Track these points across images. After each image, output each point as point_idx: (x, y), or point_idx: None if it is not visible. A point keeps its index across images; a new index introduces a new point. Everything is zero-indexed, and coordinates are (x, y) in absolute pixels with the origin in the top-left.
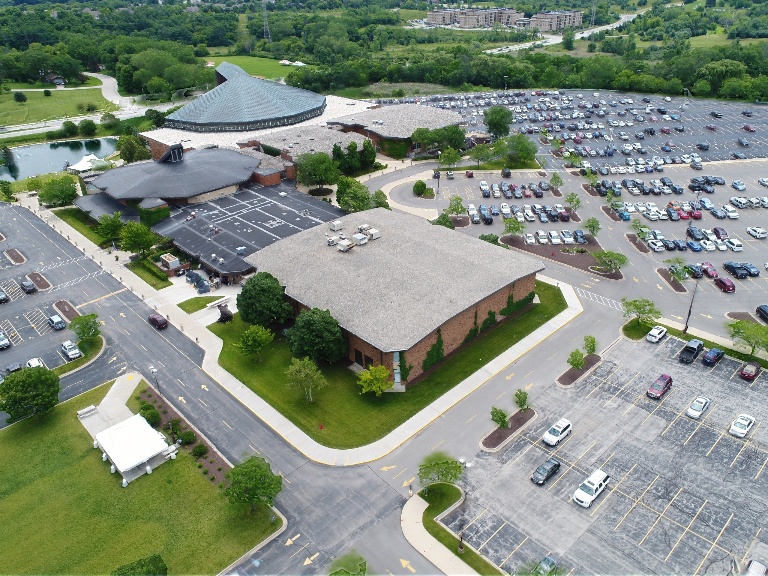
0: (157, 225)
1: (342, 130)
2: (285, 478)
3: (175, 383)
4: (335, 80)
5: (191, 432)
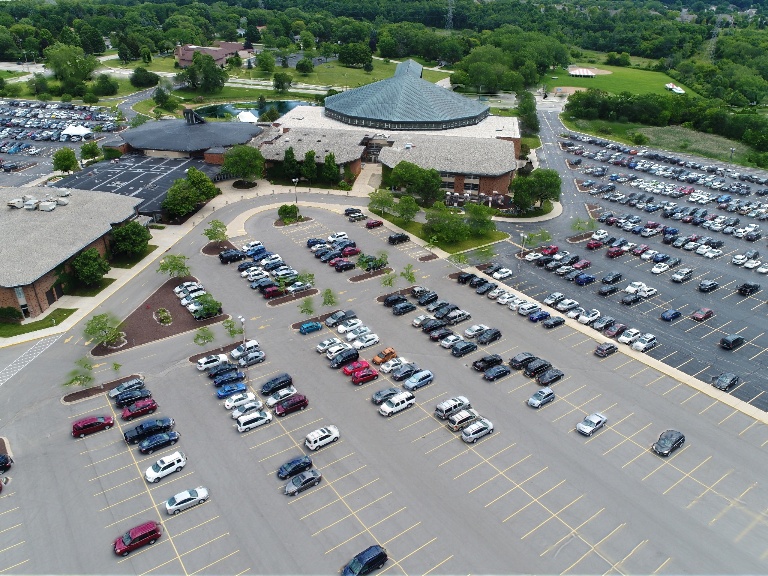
0: (105, 160)
1: (389, 145)
2: None
3: None
4: (623, 110)
5: None
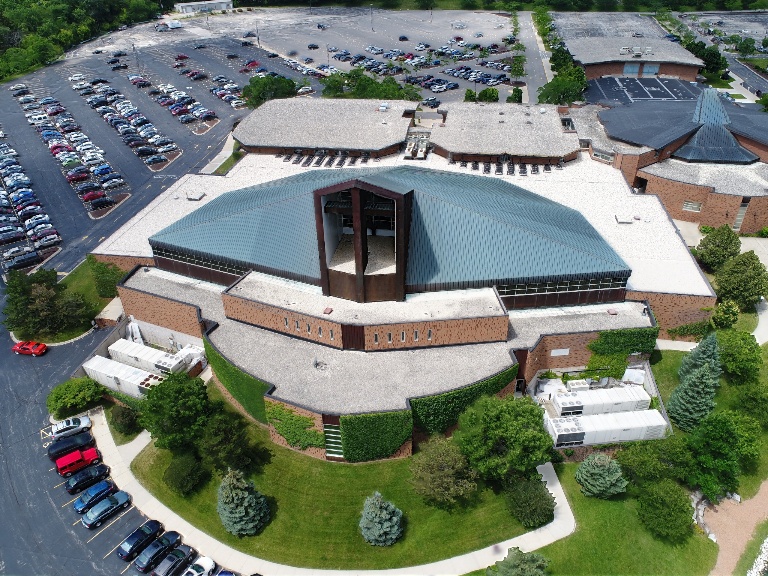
0: None
1: None
2: (729, 62)
3: (760, 81)
4: None
5: (759, 70)
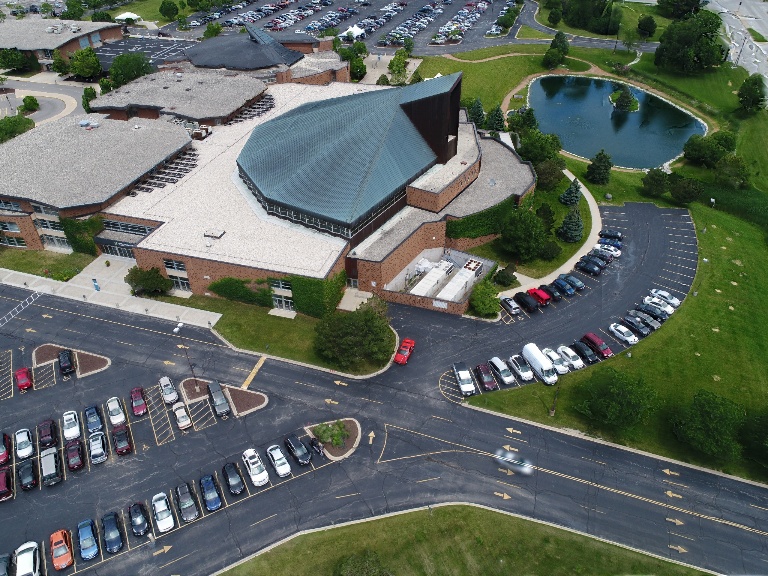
0: None
1: None
2: None
3: None
4: None
5: None
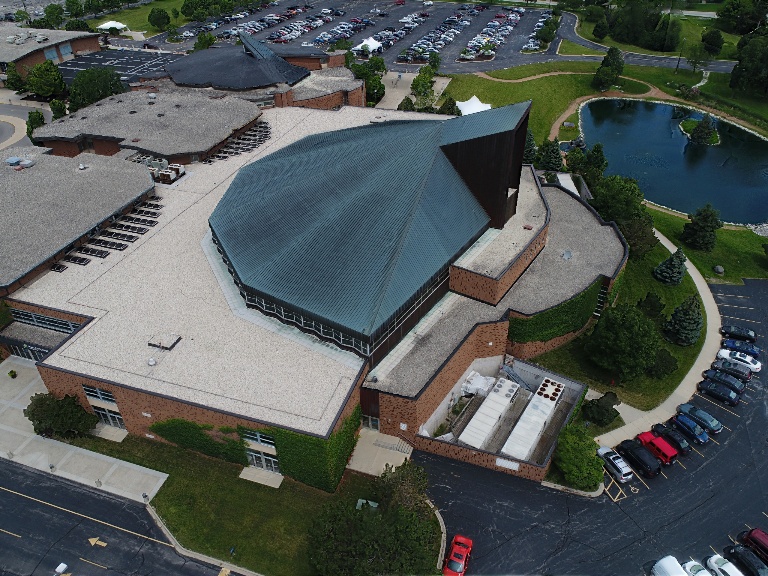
0: None
1: None
2: None
3: None
4: None
5: None
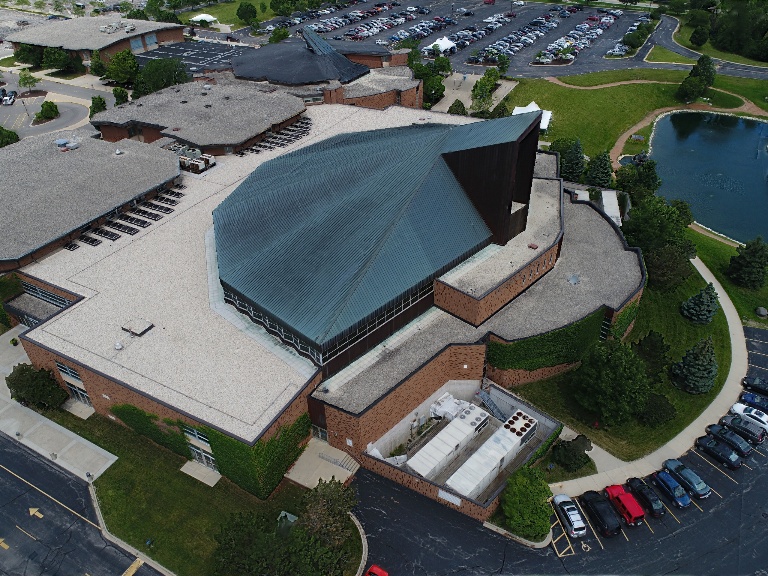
0: None
1: None
2: None
3: None
4: None
5: None
